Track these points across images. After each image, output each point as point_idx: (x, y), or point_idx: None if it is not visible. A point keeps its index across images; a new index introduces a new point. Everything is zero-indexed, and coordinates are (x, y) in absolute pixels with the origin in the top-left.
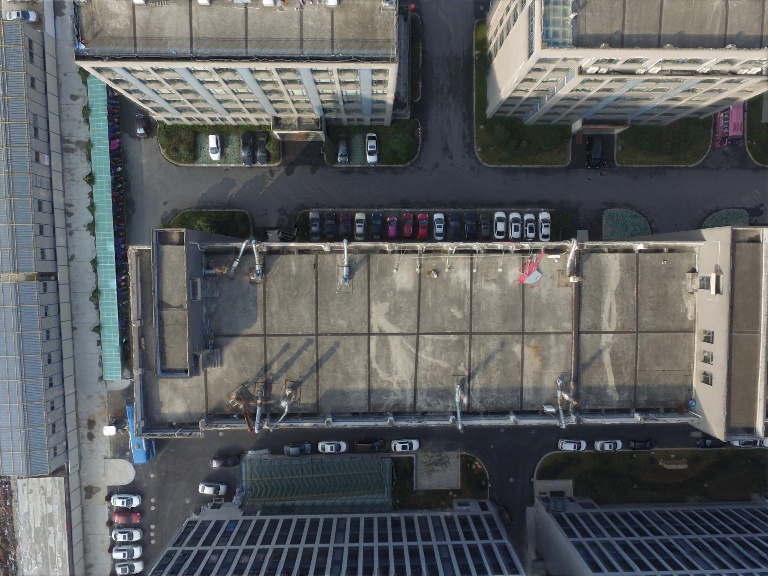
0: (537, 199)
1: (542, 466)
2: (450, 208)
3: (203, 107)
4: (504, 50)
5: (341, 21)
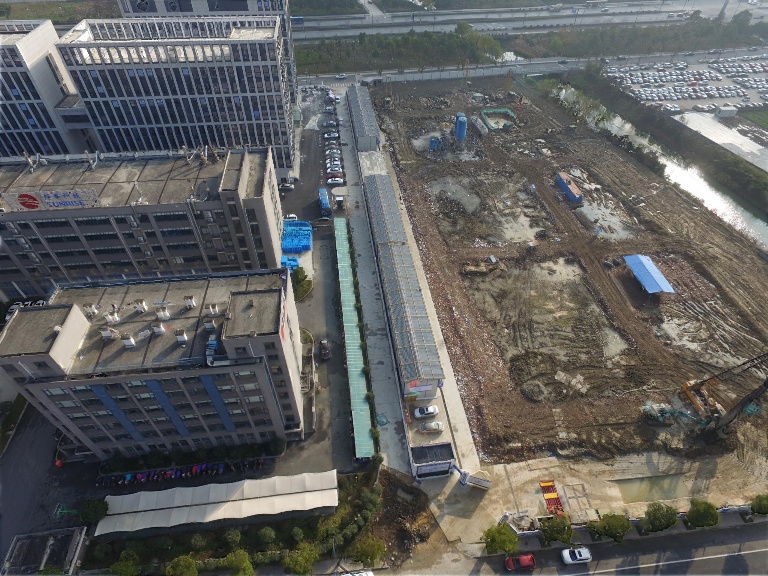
0: None
1: None
2: None
3: None
4: None
5: None
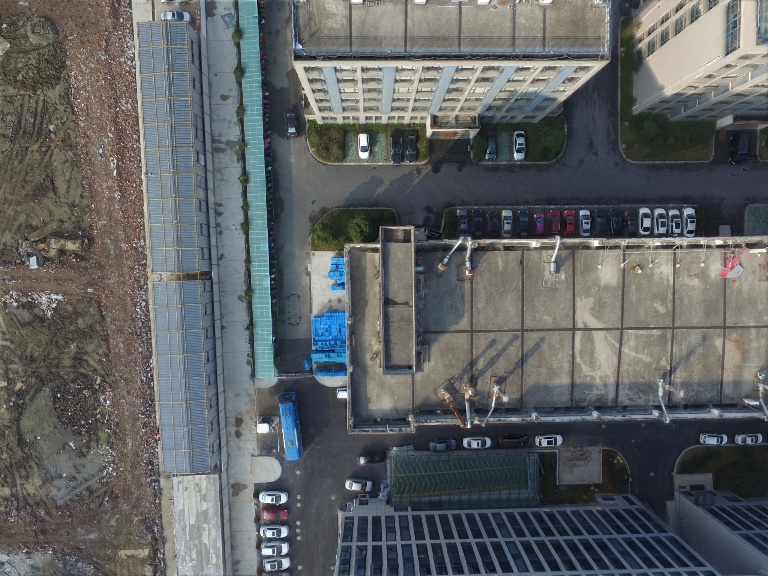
0: (680, 195)
1: (683, 460)
2: (594, 204)
3: (370, 106)
4: (673, 46)
5: (553, 19)
